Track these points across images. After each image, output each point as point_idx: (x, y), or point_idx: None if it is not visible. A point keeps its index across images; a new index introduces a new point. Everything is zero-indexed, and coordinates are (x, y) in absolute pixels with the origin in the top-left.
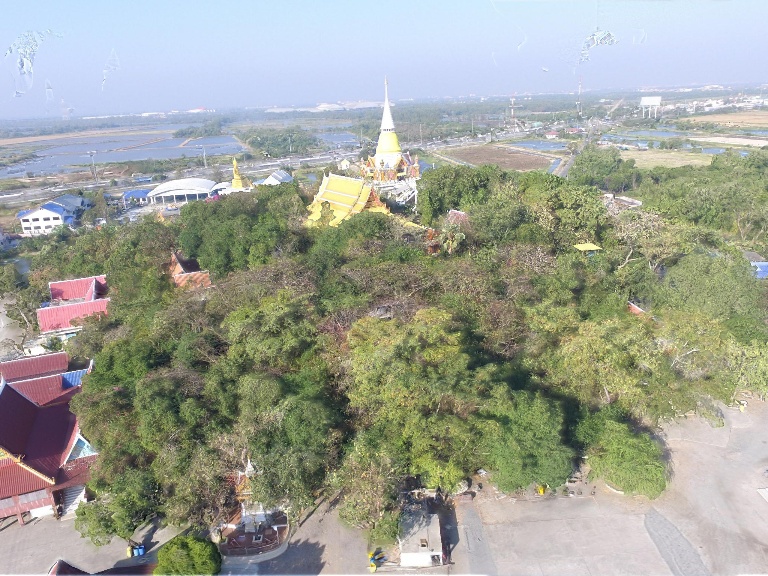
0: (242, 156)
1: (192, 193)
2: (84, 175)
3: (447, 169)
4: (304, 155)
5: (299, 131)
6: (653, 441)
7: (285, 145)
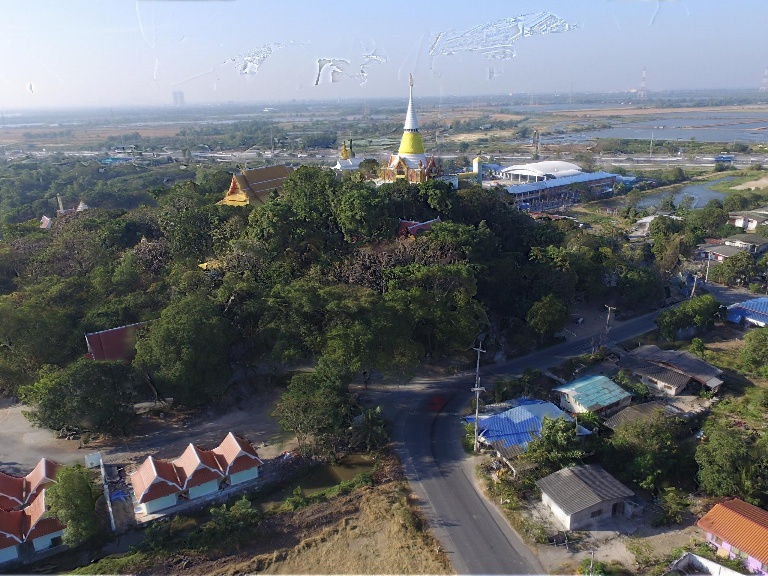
0: (732, 146)
1: (533, 175)
2: (552, 148)
3: (296, 172)
4: None
5: None
6: (7, 403)
7: None
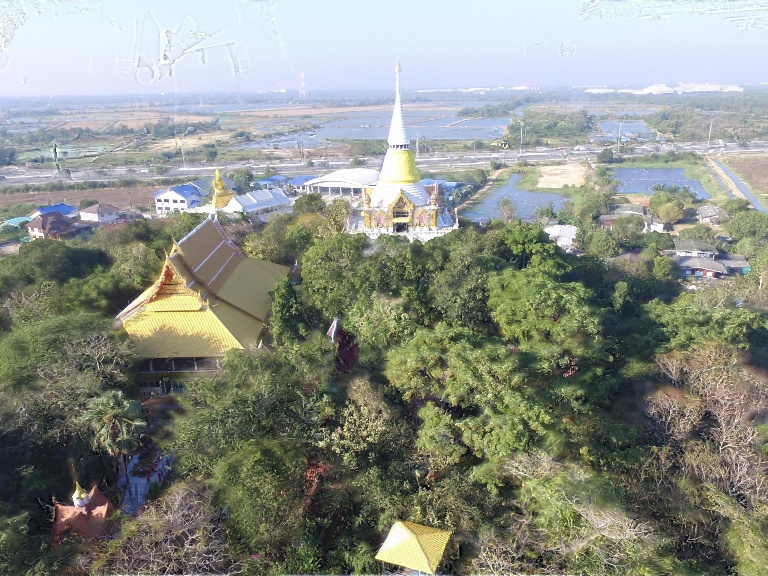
0: (473, 144)
1: (347, 186)
2: None
3: (336, 242)
4: (537, 149)
5: (572, 117)
6: None
7: (516, 135)
